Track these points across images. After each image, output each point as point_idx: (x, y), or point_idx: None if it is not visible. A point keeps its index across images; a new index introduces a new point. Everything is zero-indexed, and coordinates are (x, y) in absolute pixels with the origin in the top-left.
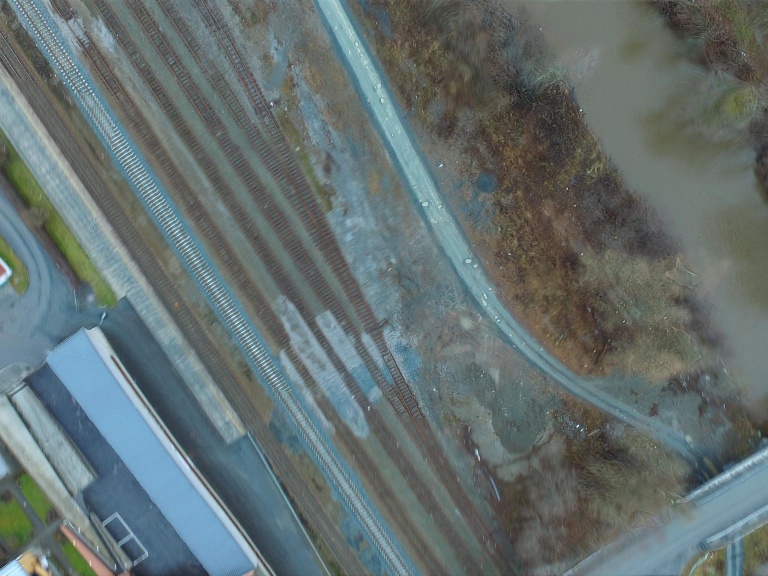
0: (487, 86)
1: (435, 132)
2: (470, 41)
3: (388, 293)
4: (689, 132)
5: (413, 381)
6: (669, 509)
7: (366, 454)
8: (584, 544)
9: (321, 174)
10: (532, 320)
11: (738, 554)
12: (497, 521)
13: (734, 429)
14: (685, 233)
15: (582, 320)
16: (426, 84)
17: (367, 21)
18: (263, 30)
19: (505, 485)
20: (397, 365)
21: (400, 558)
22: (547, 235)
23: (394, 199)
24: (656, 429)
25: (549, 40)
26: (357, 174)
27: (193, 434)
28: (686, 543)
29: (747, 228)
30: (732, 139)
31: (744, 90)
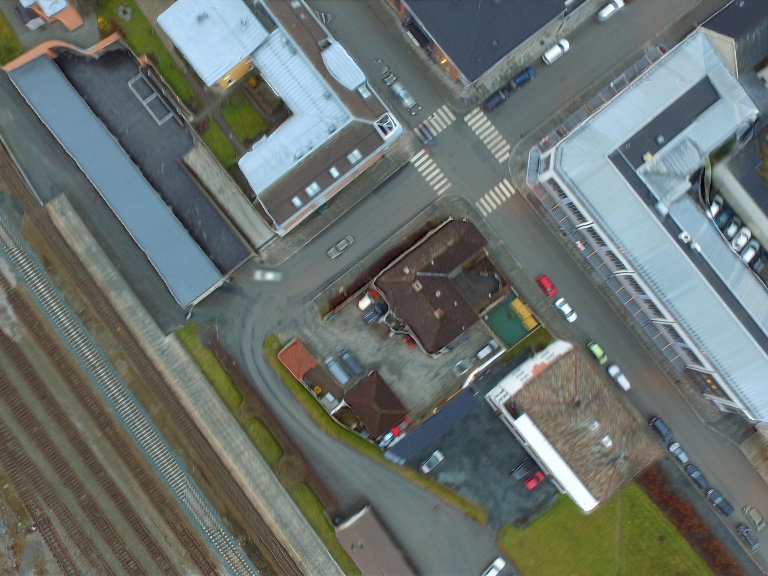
0: None
1: None
2: None
3: None
4: None
5: None
6: None
7: None
8: None
9: None
10: None
11: None
12: None
13: None
14: None
15: None
16: None
17: None
18: None
19: None
20: None
21: None
22: None
23: None
24: None
25: None
26: None
27: (99, 202)
28: None
29: None
30: None
31: None
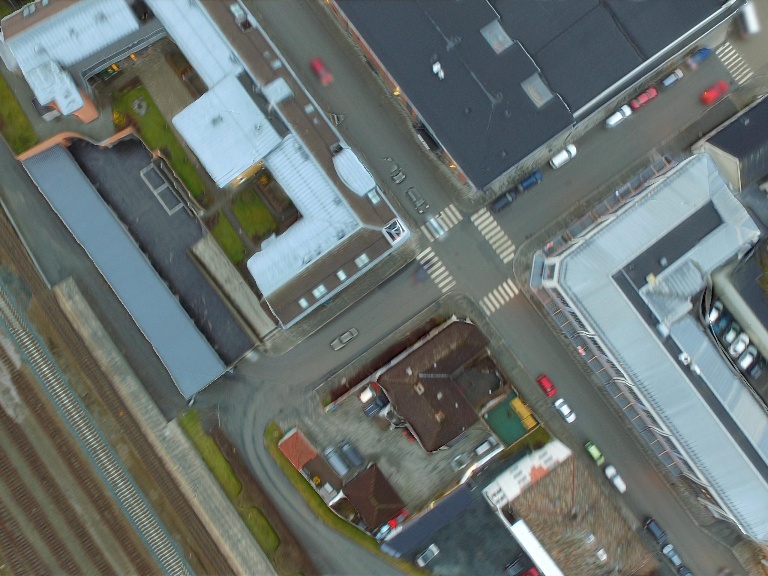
0: None
1: None
2: None
3: None
4: None
5: None
6: None
7: None
8: None
9: None
10: None
11: None
12: None
13: None
14: None
15: None
16: None
17: None
18: None
19: None
20: None
21: None
22: None
23: None
24: None
25: None
26: None
27: (107, 287)
28: None
29: None
30: None
31: None
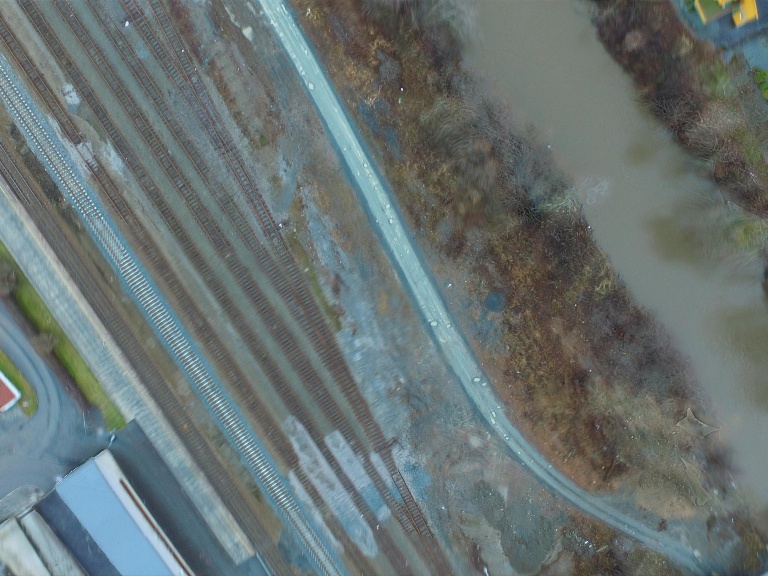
0: (496, 207)
1: (444, 252)
2: (479, 167)
3: (397, 412)
4: (698, 255)
5: (422, 500)
6: None
7: (375, 573)
8: None
9: (330, 295)
10: (541, 437)
11: None
12: None
13: (742, 543)
14: (693, 347)
15: (591, 438)
16: (435, 204)
17: (376, 142)
18: (272, 152)
19: None
20: (406, 484)
21: None
22: (556, 353)
23: (403, 319)
24: (664, 544)
25: (557, 157)
26: (366, 294)
27: (202, 555)
28: None
29: (755, 344)
30: (741, 263)
31: (753, 223)
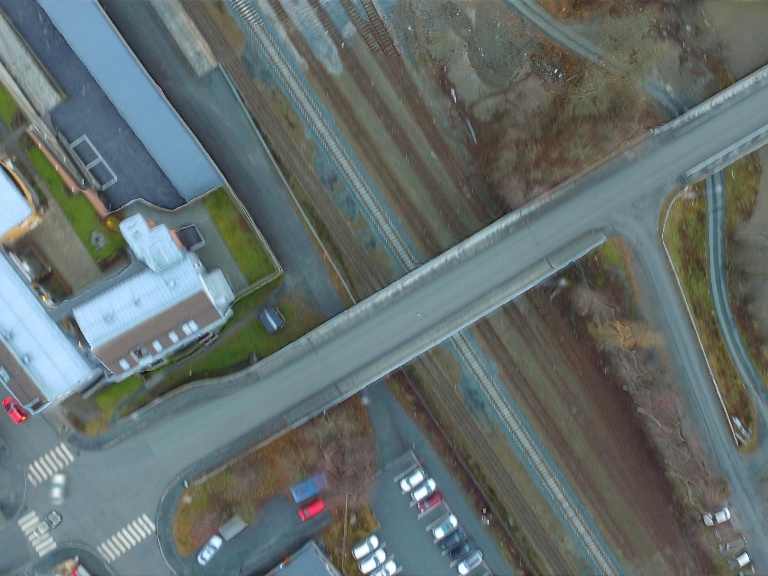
0: None
1: None
2: None
3: None
4: None
5: (388, 18)
6: (648, 141)
7: (340, 92)
8: (561, 170)
9: None
10: None
11: (719, 208)
12: (474, 165)
13: (715, 80)
14: None
15: None
16: None
17: None
18: None
19: (482, 125)
20: (371, 1)
21: (375, 200)
22: None
23: None
24: (636, 77)
25: None
26: None
27: (163, 66)
28: (665, 176)
29: None
30: None
31: None
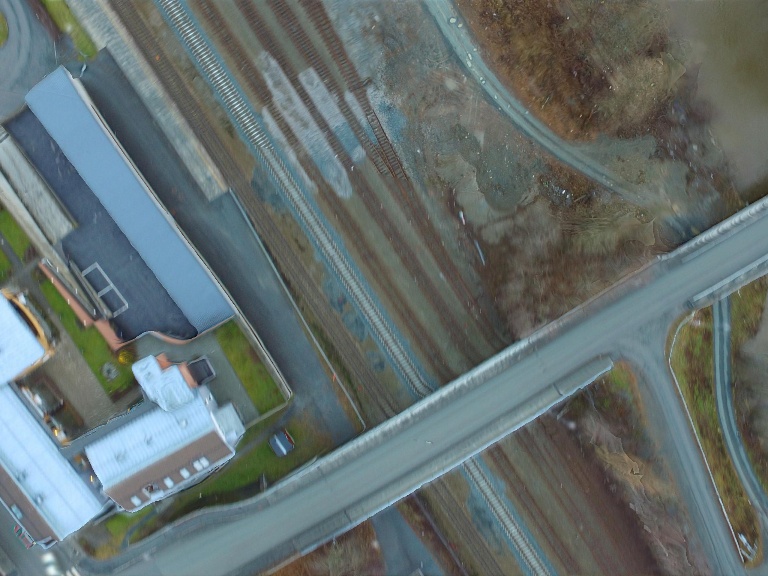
0: None
1: None
2: None
3: (372, 51)
4: None
5: (397, 141)
6: (655, 266)
7: (349, 215)
8: (569, 297)
9: None
10: (517, 82)
11: (726, 326)
12: (482, 286)
13: (722, 199)
14: (672, 2)
15: (568, 82)
16: None
17: None
18: None
19: (490, 247)
20: (381, 125)
21: (384, 322)
22: None
23: None
24: (643, 197)
25: None
26: None
27: (174, 190)
28: (672, 301)
29: None
30: None
31: None
